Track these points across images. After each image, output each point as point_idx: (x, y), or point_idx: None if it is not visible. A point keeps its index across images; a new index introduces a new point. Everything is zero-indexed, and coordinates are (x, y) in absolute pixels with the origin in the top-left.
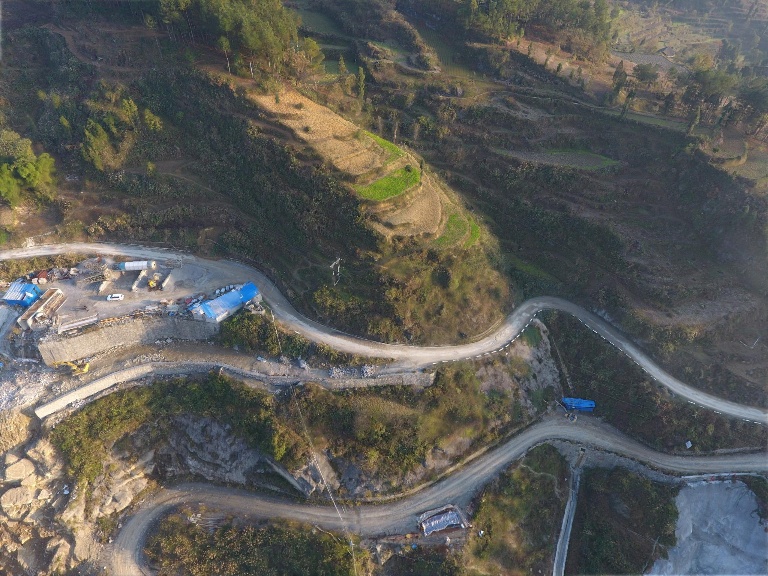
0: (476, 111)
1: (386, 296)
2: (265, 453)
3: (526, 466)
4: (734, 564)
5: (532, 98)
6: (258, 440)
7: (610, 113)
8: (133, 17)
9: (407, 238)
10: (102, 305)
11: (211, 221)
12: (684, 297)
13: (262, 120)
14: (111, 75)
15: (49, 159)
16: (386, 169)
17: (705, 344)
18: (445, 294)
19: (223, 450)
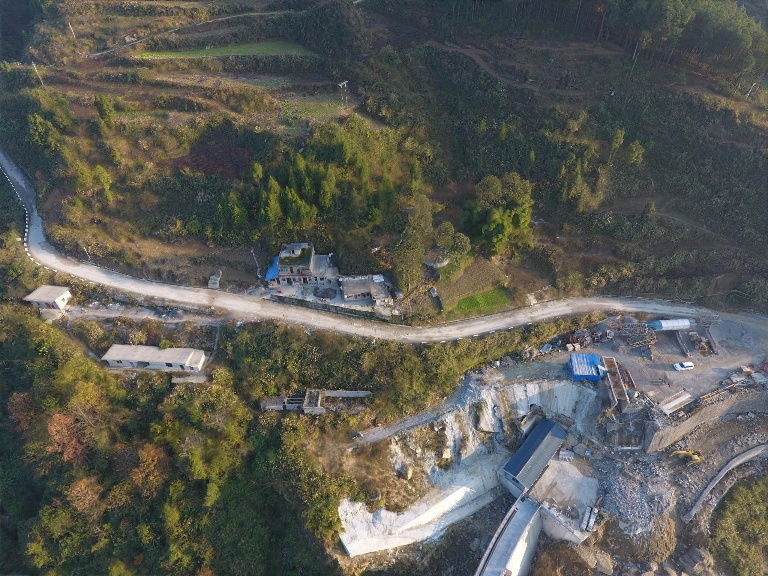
0: None
1: None
2: None
3: None
4: None
5: None
6: None
7: None
8: (572, 32)
9: None
10: (676, 376)
11: (720, 267)
12: None
13: None
14: (556, 100)
15: None
16: None
17: None
18: None
19: None
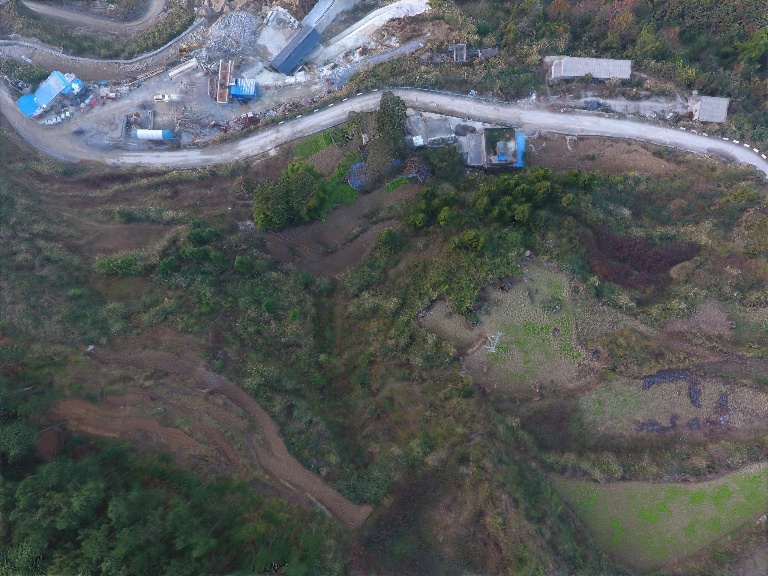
0: None
1: None
2: None
3: None
4: None
5: None
6: None
7: None
8: None
9: None
10: (172, 91)
11: (74, 186)
12: None
13: None
14: (177, 350)
15: (259, 222)
16: None
17: None
18: None
19: None
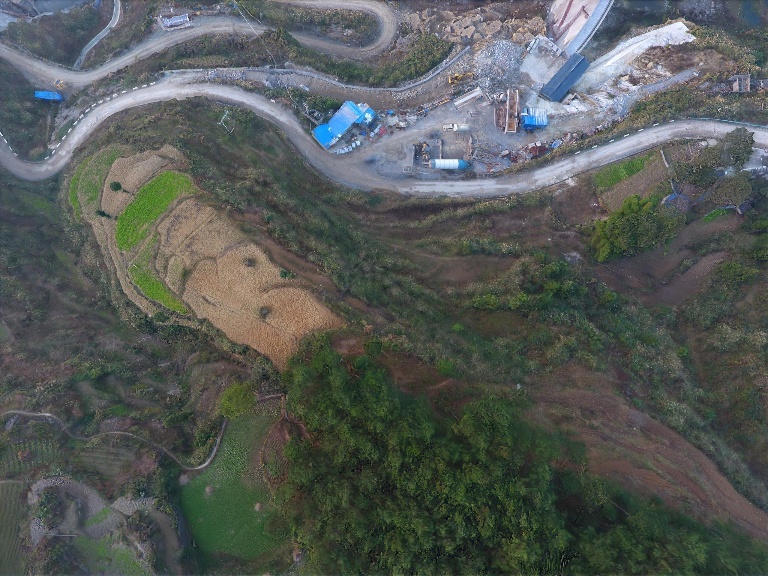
0: (1, 389)
1: None
2: None
3: None
4: None
5: None
6: None
7: None
8: None
9: None
10: (459, 120)
11: (386, 216)
12: None
13: None
14: None
15: None
16: None
17: None
18: None
19: None
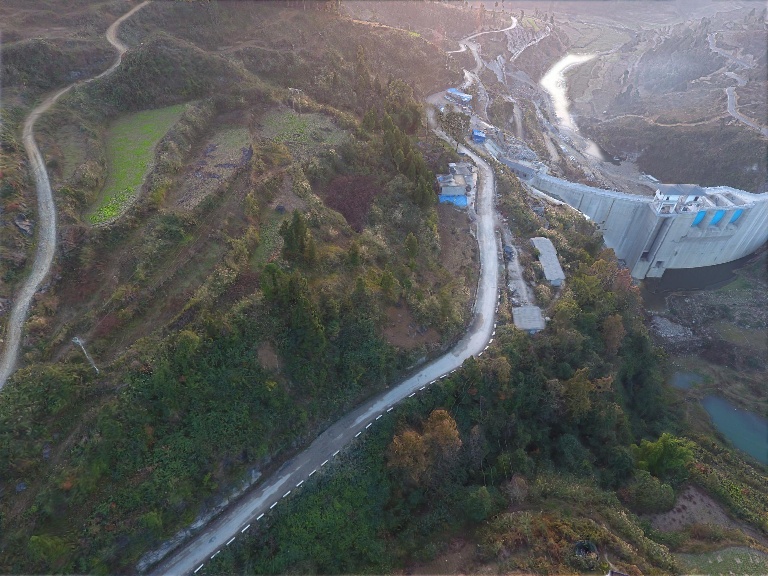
0: None
1: None
2: None
3: None
4: None
5: None
6: None
7: None
8: None
9: None
10: (472, 122)
11: None
12: None
13: None
14: None
15: None
16: None
17: None
18: None
19: None
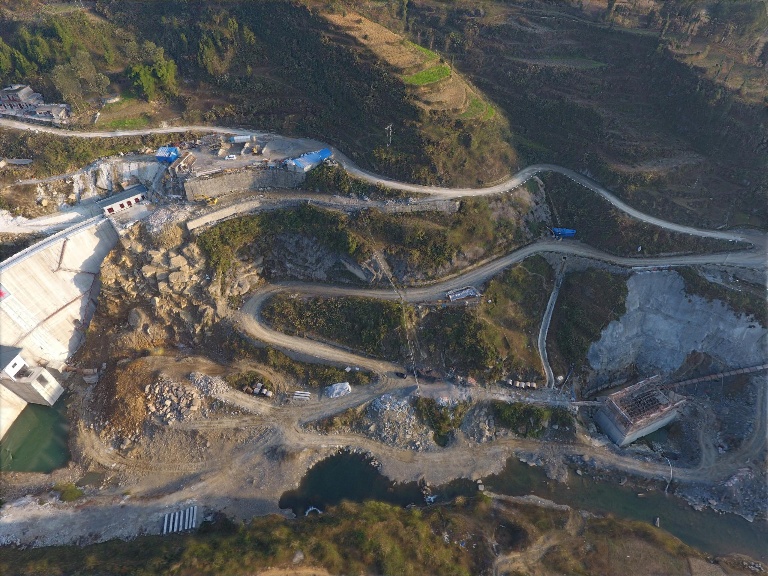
0: (495, 28)
1: (425, 151)
2: (341, 253)
3: (523, 267)
4: (666, 326)
5: (540, 18)
6: (336, 245)
7: (601, 26)
8: None
9: (440, 112)
10: (222, 162)
11: (293, 110)
12: (646, 155)
13: (331, 32)
14: (214, 3)
15: (174, 65)
16: (425, 66)
17: (658, 185)
18: (468, 152)
19: (311, 256)
